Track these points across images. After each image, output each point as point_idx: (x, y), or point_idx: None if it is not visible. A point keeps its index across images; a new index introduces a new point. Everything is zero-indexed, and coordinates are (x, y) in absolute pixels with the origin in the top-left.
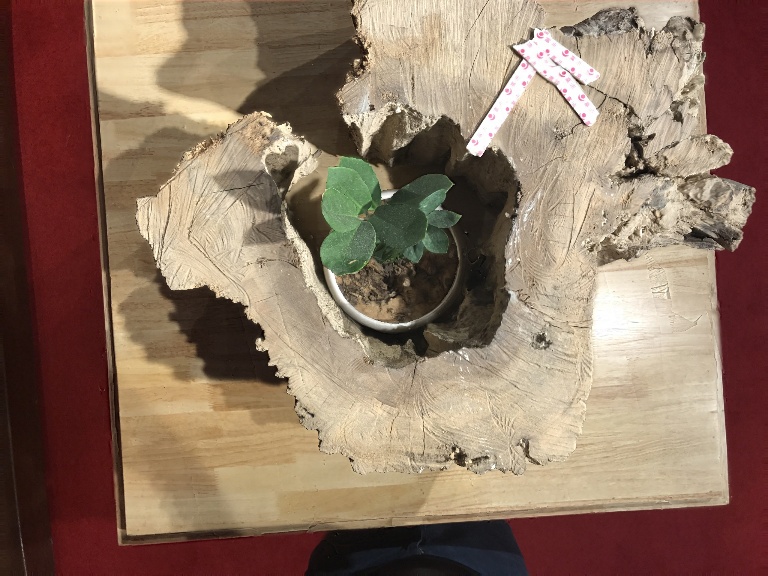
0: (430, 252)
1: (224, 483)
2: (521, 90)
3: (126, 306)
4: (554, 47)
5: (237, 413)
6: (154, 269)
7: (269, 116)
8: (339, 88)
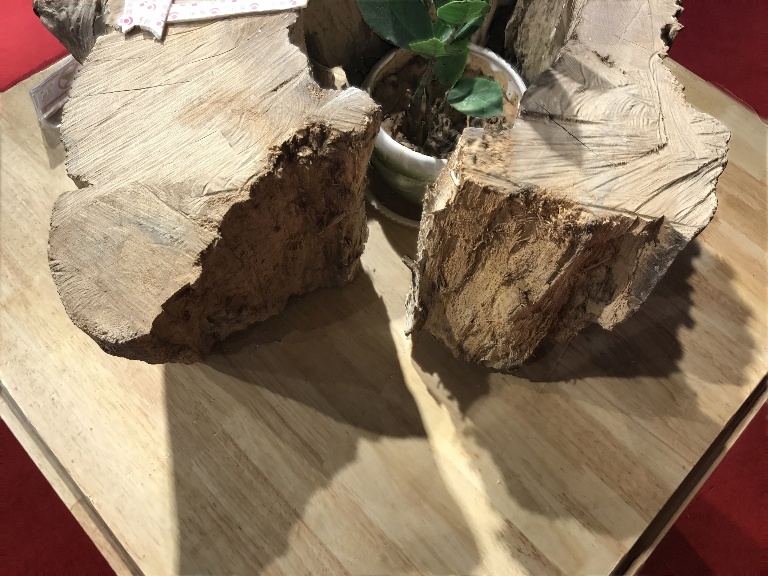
0: (408, 97)
1: (759, 164)
2: (204, 3)
3: (733, 378)
4: (133, 3)
5: None
6: (670, 382)
7: None
8: (350, 148)
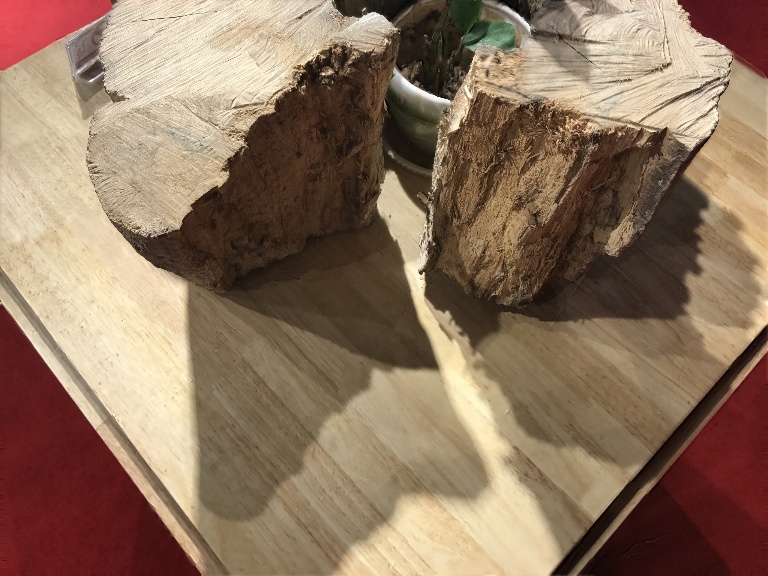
0: (425, 49)
1: None
2: None
3: (739, 321)
4: None
5: (706, 155)
6: (676, 323)
7: (467, 88)
8: (370, 68)
